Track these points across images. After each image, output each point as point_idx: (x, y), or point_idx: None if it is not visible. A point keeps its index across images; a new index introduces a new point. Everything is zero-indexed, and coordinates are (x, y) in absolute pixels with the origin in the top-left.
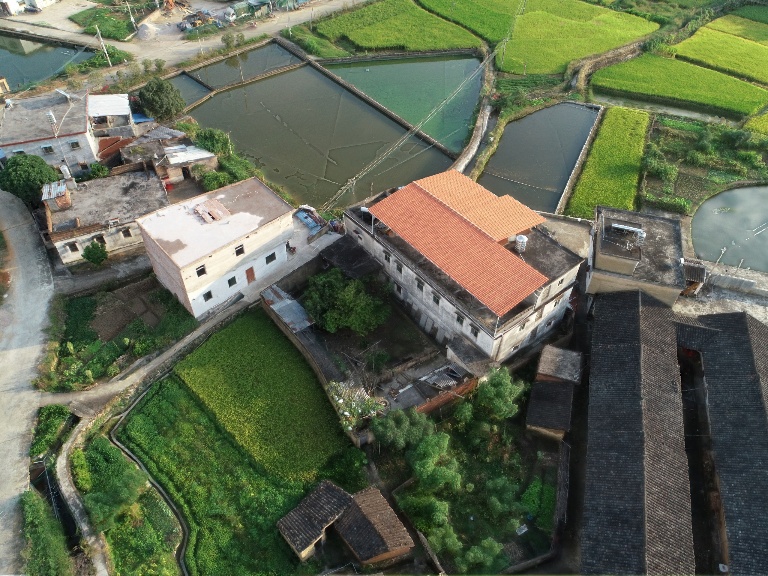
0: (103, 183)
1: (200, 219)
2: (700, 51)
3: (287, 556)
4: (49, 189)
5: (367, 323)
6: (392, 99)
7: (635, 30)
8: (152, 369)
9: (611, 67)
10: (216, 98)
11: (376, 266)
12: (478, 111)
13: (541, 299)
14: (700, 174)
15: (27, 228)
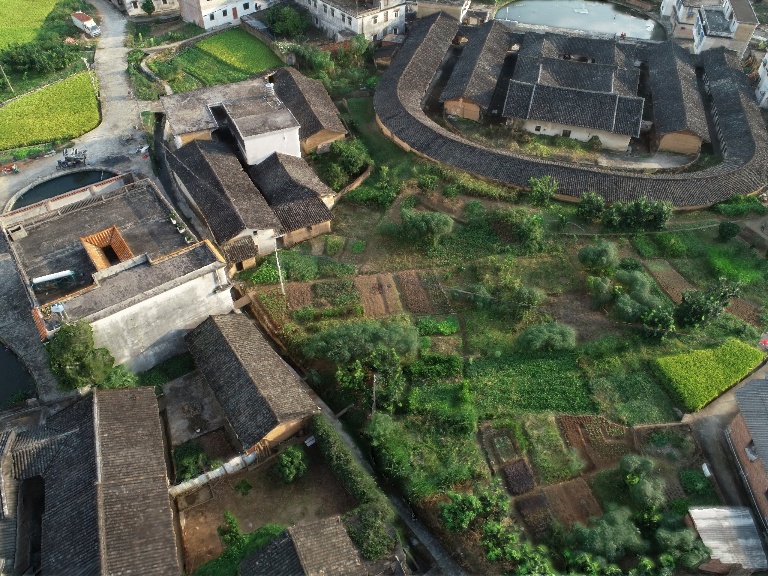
0: None
1: None
2: None
3: None
4: None
5: (296, 26)
6: None
7: None
8: (184, 42)
9: None
10: None
11: (304, 9)
12: None
13: (384, 4)
14: None
15: (106, 3)
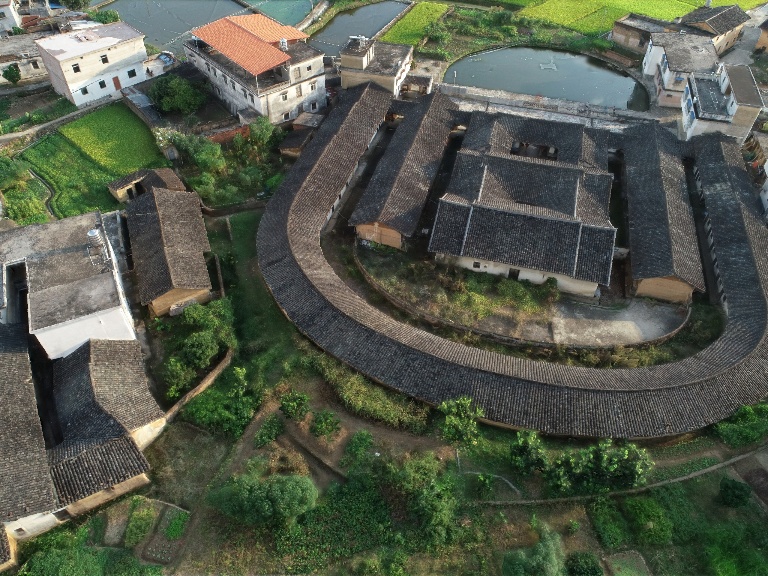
0: (21, 37)
1: (78, 40)
2: None
3: (112, 201)
4: None
5: (189, 103)
6: (257, 0)
7: None
8: (43, 127)
9: None
10: (122, 2)
11: (204, 77)
12: (316, 4)
13: (294, 77)
14: (469, 40)
15: None
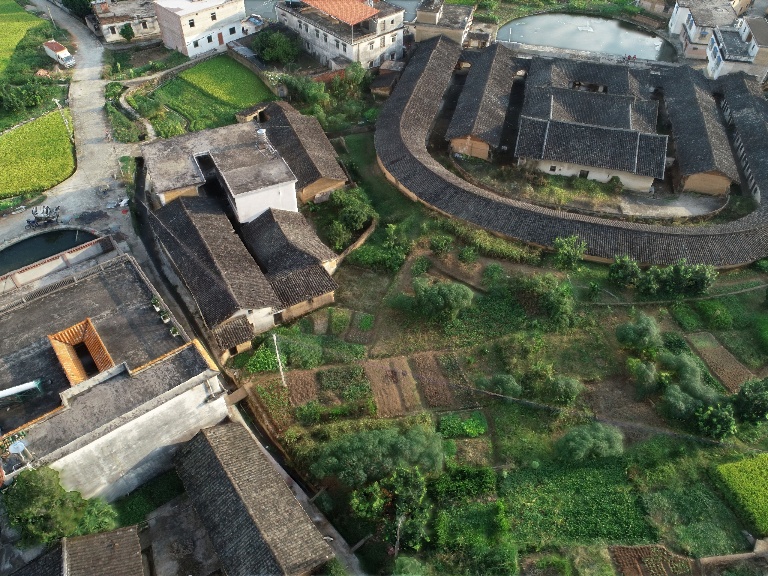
0: (127, 2)
1: (190, 0)
2: None
3: None
4: (95, 2)
5: (287, 53)
6: None
7: None
8: (166, 73)
9: None
10: None
11: (295, 33)
12: None
13: (380, 29)
14: (513, 7)
15: (81, 28)
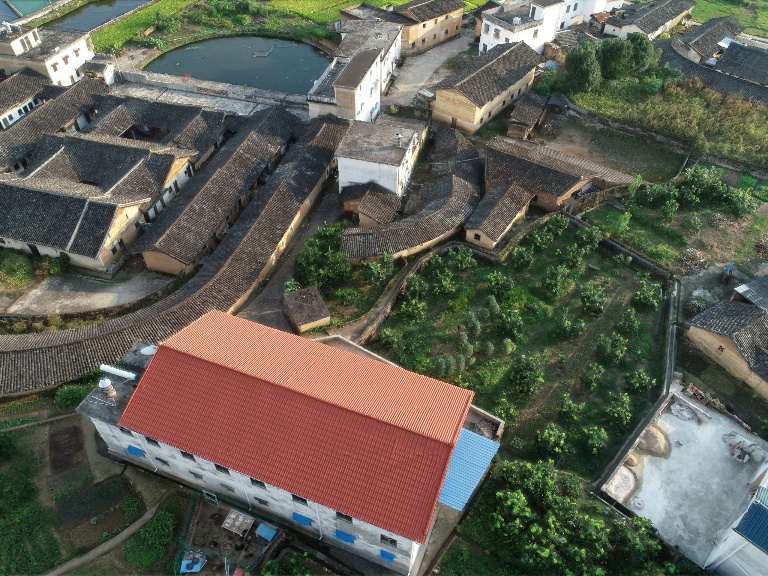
0: None
1: None
2: None
3: None
4: None
5: None
6: None
7: None
8: None
9: None
10: None
11: None
12: None
13: None
14: (198, 29)
15: None
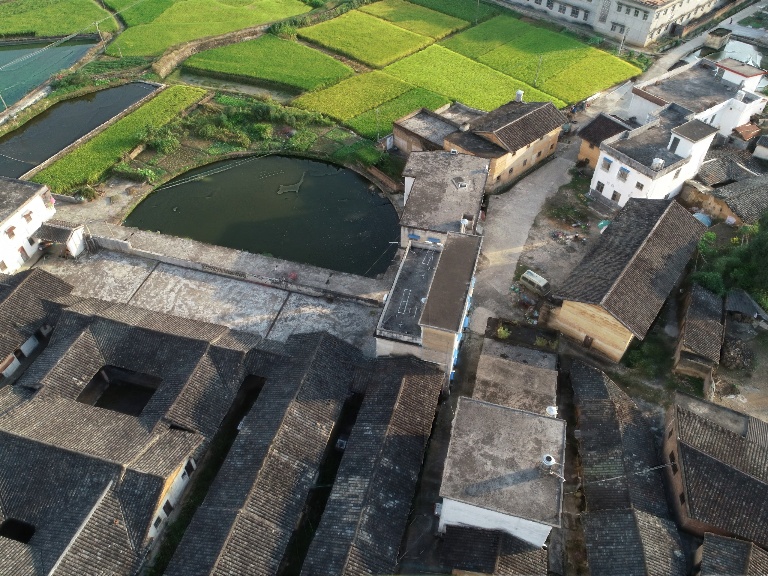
0: None
1: None
2: (326, 32)
3: None
4: None
5: None
6: None
7: (282, 13)
8: None
9: (217, 48)
10: None
11: None
12: (30, 91)
13: None
14: (203, 146)
15: None
